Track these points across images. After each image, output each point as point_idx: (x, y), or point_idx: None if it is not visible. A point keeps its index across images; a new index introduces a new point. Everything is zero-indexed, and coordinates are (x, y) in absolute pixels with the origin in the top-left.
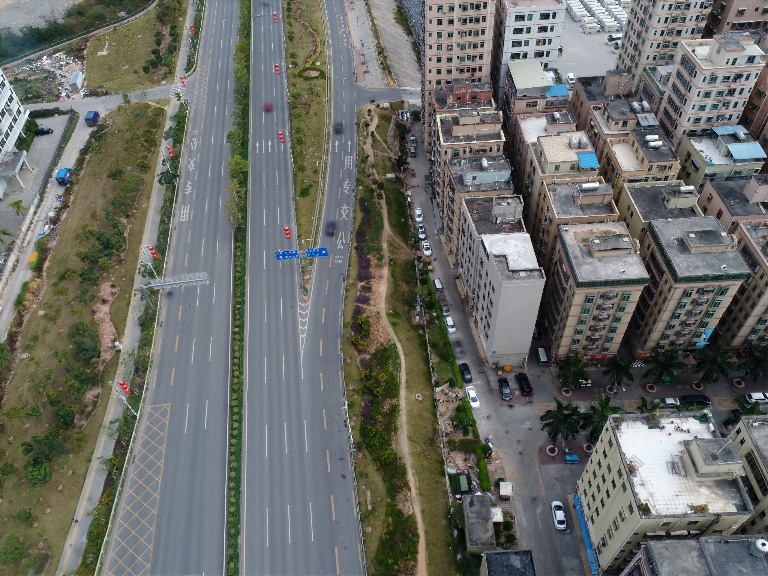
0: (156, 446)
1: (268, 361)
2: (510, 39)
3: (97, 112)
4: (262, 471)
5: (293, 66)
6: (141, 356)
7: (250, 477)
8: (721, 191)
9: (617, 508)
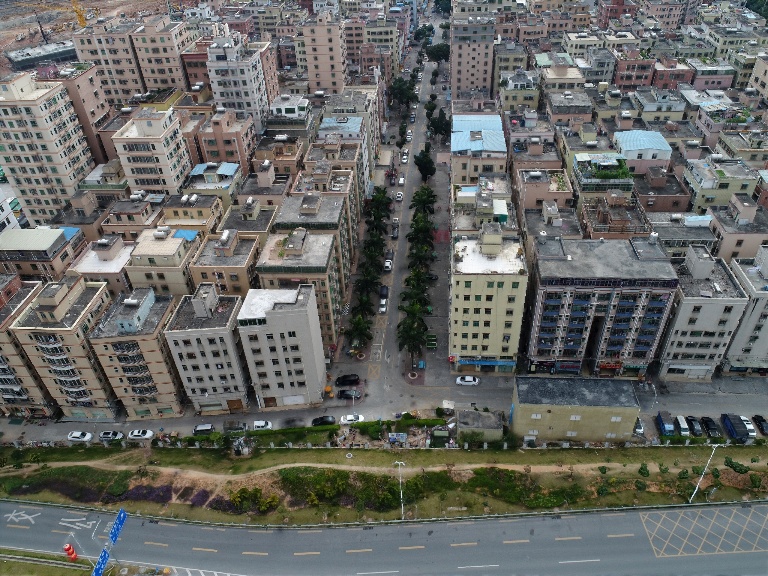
0: None
1: None
2: None
3: None
4: None
5: None
6: None
7: None
8: None
9: (504, 304)
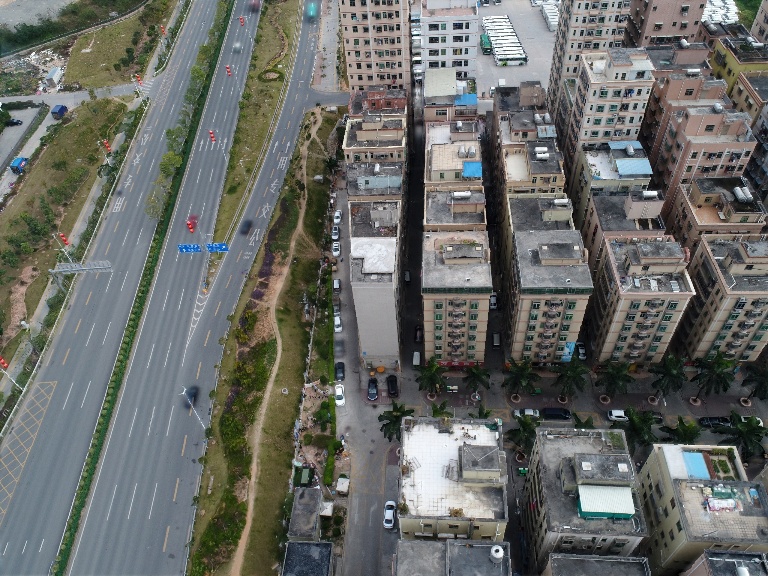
0: (34, 420)
1: (155, 348)
2: (426, 48)
3: (65, 106)
4: (121, 450)
5: (252, 68)
6: (39, 336)
7: (109, 455)
8: (602, 206)
9: None
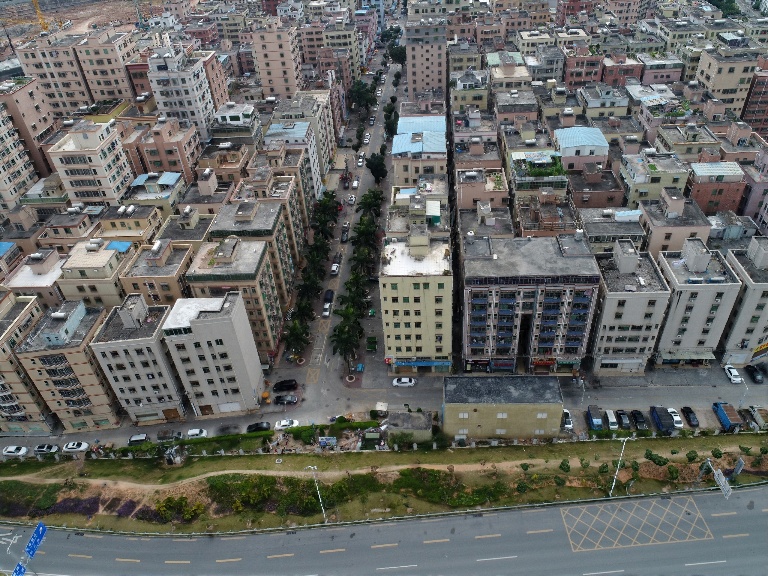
0: None
1: None
2: None
3: None
4: None
5: None
6: None
7: None
8: None
9: (432, 305)
